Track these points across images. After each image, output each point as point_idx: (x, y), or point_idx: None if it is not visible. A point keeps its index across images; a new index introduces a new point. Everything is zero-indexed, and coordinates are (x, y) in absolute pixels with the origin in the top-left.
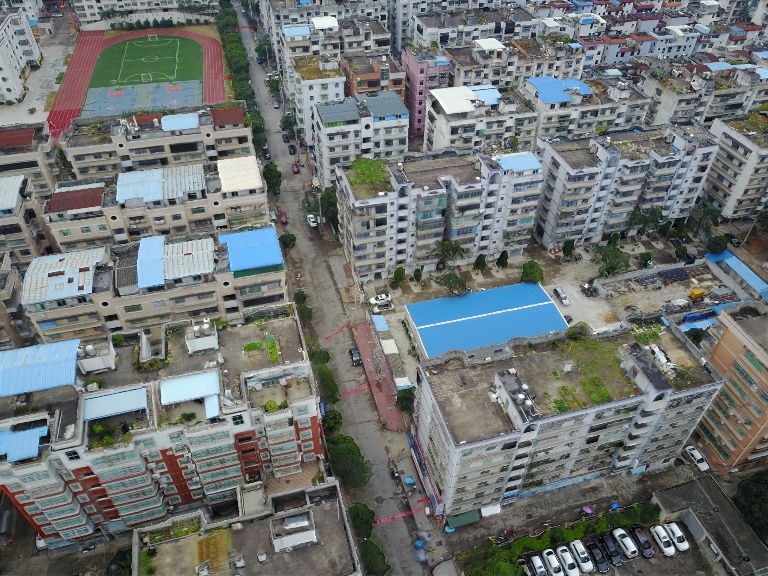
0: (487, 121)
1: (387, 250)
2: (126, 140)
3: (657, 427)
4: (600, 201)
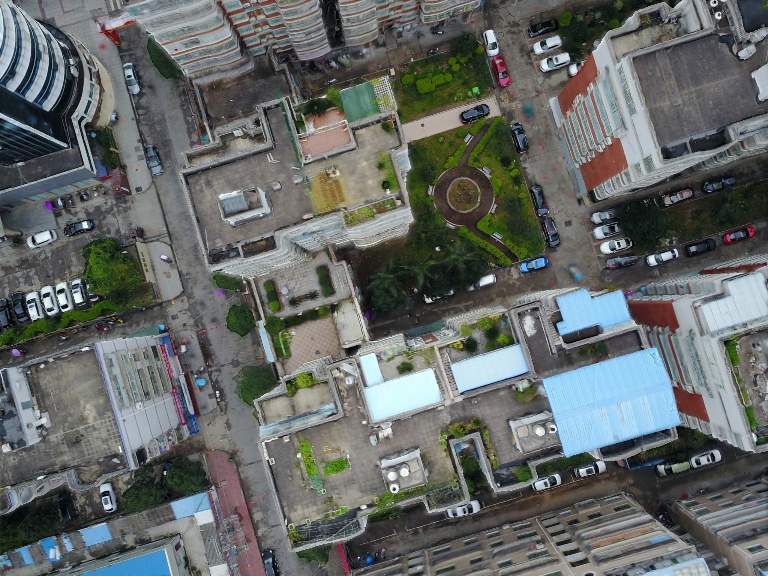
0: None
1: None
2: None
3: None
4: None
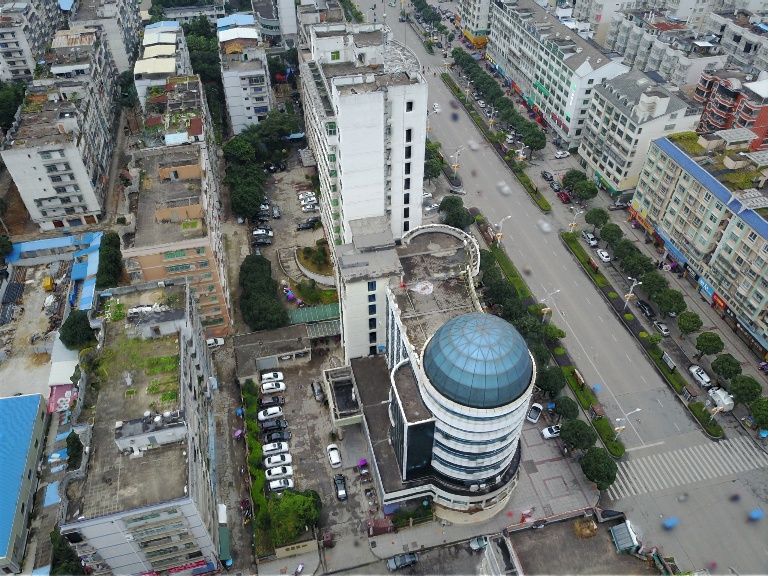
0: None
1: None
2: None
3: (199, 344)
4: None
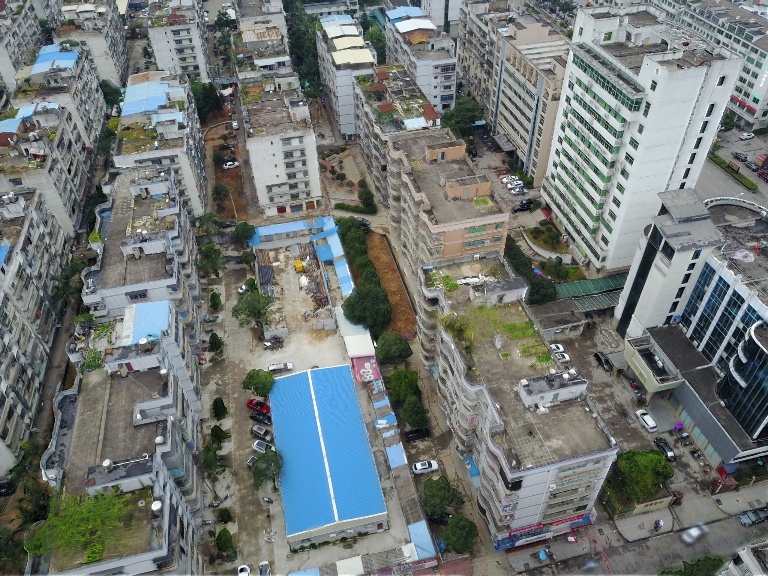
0: None
1: None
2: None
3: None
4: None
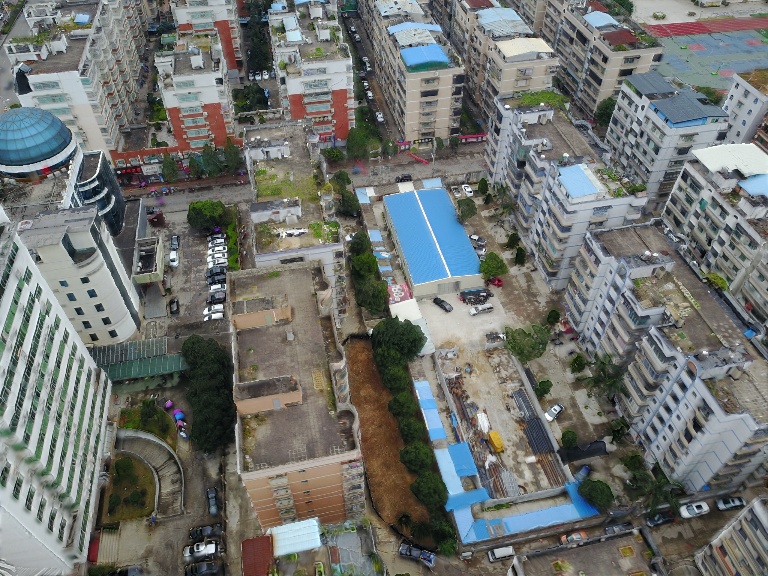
0: (714, 196)
1: (496, 163)
2: (567, 8)
3: None
4: (606, 315)
